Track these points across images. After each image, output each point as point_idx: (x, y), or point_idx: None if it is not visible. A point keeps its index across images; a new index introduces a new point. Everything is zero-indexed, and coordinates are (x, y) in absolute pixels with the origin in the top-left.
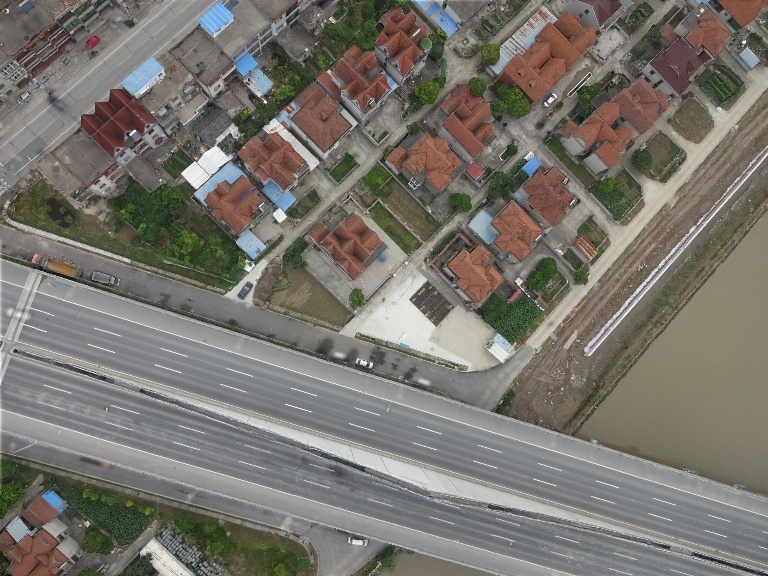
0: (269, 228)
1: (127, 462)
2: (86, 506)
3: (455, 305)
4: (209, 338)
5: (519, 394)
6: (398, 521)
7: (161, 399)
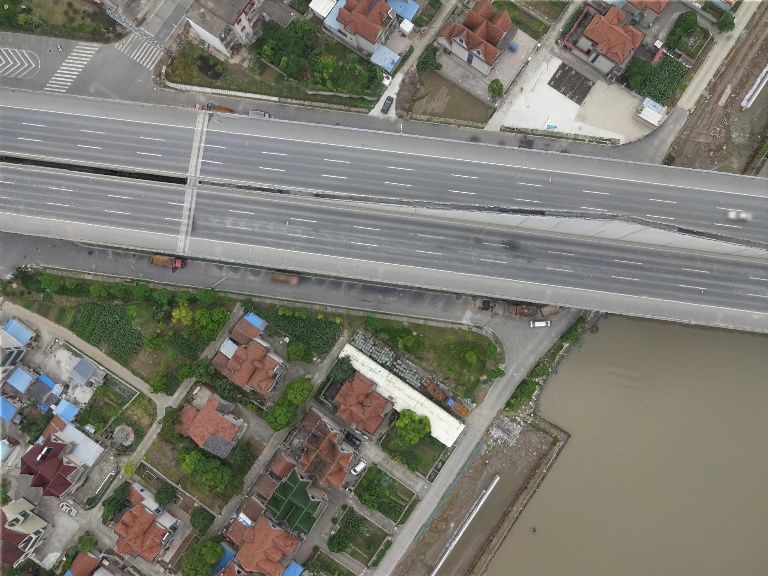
0: (398, 42)
1: (314, 267)
2: (283, 322)
3: (595, 81)
4: (366, 142)
5: (679, 159)
6: (581, 285)
7: (336, 198)
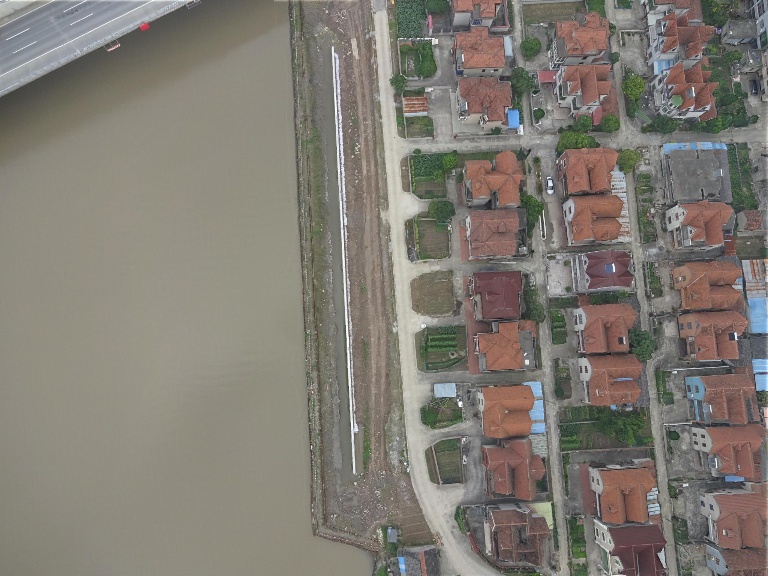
0: None
1: None
2: None
3: None
4: None
5: None
6: None
7: None
